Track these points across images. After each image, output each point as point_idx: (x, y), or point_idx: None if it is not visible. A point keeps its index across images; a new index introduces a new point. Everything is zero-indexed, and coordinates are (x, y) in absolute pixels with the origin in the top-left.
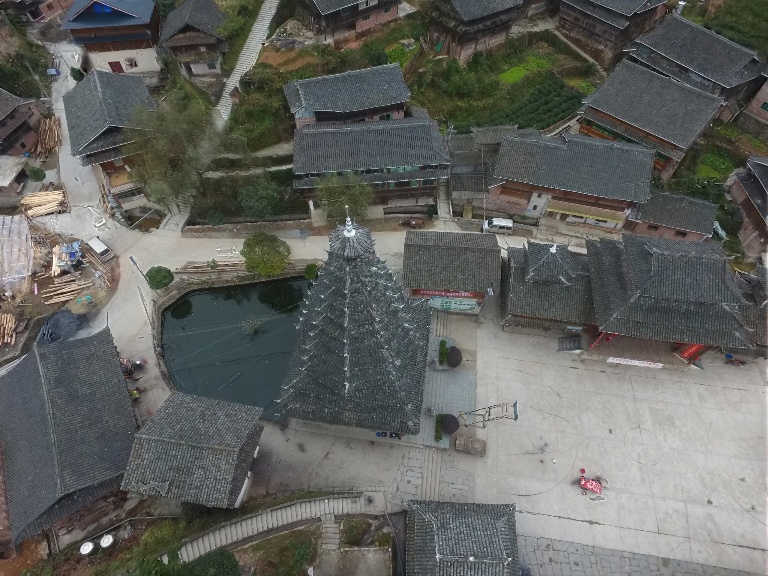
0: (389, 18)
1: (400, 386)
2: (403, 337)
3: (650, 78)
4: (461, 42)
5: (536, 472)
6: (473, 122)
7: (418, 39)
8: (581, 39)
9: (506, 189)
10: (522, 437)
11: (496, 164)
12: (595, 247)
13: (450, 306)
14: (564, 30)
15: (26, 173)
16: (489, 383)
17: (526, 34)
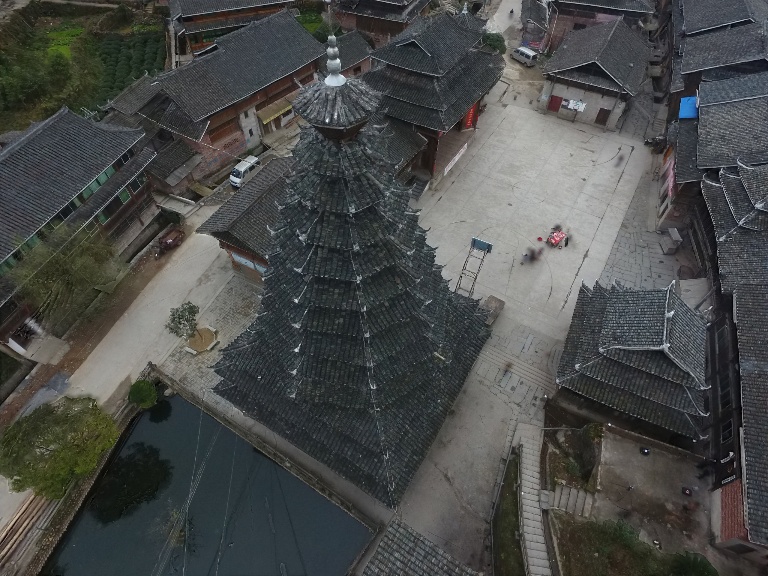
0: None
1: None
2: None
3: None
4: None
5: (531, 273)
6: None
7: None
8: None
9: (212, 134)
10: (493, 267)
11: (183, 109)
12: None
13: None
14: None
15: None
16: None
17: (15, 14)
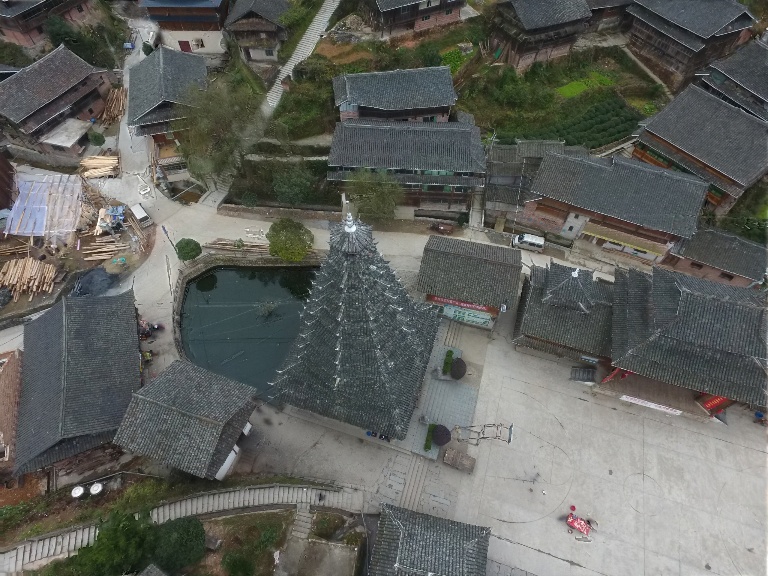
0: (450, 20)
1: (391, 389)
2: (399, 340)
3: (717, 106)
4: (520, 51)
5: (523, 500)
6: (521, 133)
7: (477, 44)
8: (651, 59)
9: (542, 206)
10: (515, 462)
11: (534, 179)
12: (624, 277)
13: (463, 317)
14: (634, 48)
15: (88, 137)
16: (490, 401)
17: (592, 48)
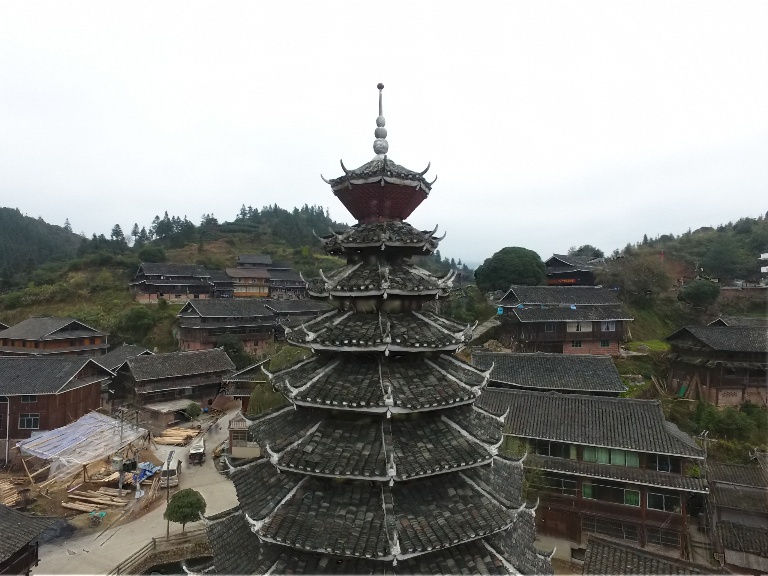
0: None
1: None
2: None
3: None
4: (716, 382)
5: None
6: None
7: (648, 377)
8: None
9: None
10: None
11: None
12: None
13: None
14: None
15: (187, 408)
16: None
17: None
